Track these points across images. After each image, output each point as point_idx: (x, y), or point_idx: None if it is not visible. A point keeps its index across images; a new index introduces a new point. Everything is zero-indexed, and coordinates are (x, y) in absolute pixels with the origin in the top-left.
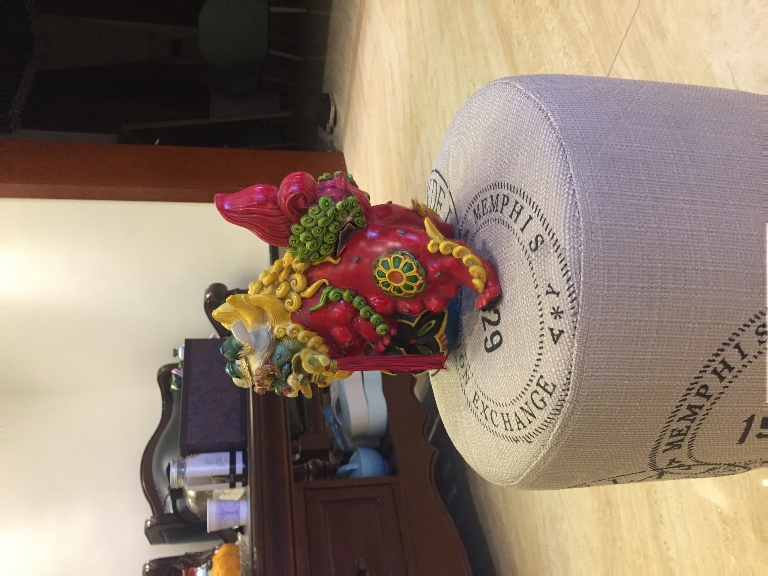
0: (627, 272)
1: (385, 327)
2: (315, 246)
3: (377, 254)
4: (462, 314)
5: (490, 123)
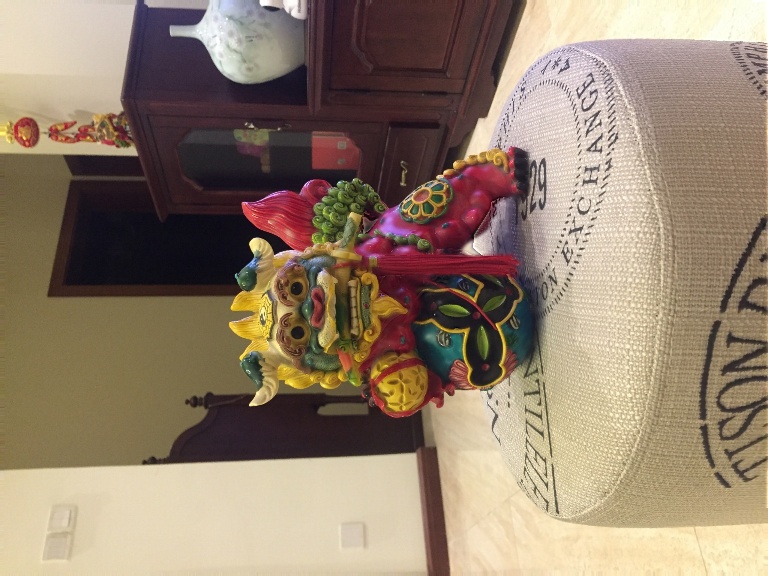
0: None
1: (427, 241)
2: (339, 219)
3: None
4: (524, 275)
5: None
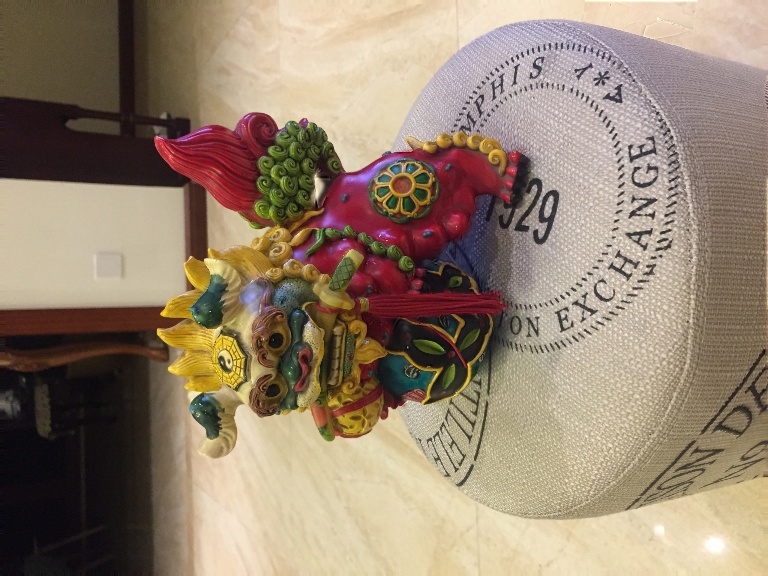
0: (638, 40)
1: (410, 259)
2: (291, 186)
3: (368, 180)
4: (486, 282)
5: (425, 107)
